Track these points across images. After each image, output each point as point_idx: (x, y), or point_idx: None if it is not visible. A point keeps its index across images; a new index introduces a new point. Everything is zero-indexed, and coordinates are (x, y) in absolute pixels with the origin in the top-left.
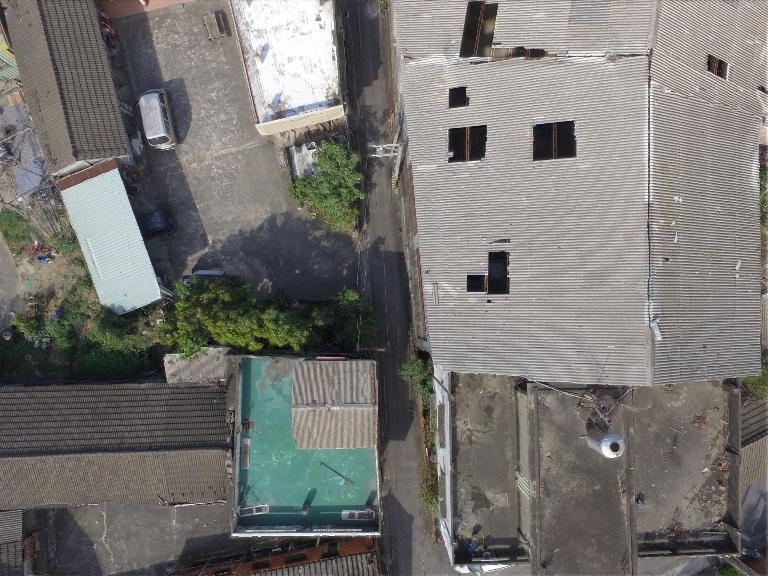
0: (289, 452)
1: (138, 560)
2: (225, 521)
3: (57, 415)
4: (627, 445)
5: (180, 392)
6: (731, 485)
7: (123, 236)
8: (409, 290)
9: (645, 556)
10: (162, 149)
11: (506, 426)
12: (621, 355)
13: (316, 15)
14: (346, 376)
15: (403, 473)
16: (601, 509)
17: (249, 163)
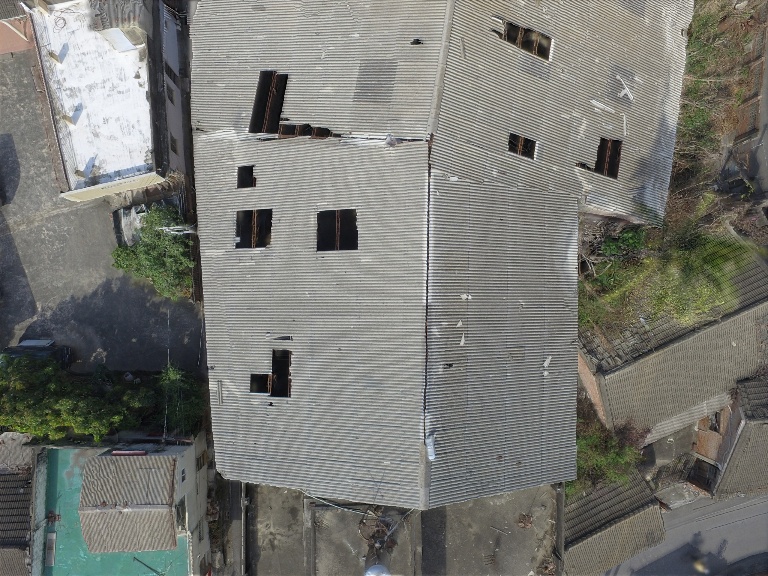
0: None
1: None
2: None
3: None
4: (413, 566)
5: None
6: None
7: None
8: None
9: None
10: None
11: None
12: (397, 473)
13: (135, 72)
14: (143, 473)
15: None
16: None
17: (83, 224)
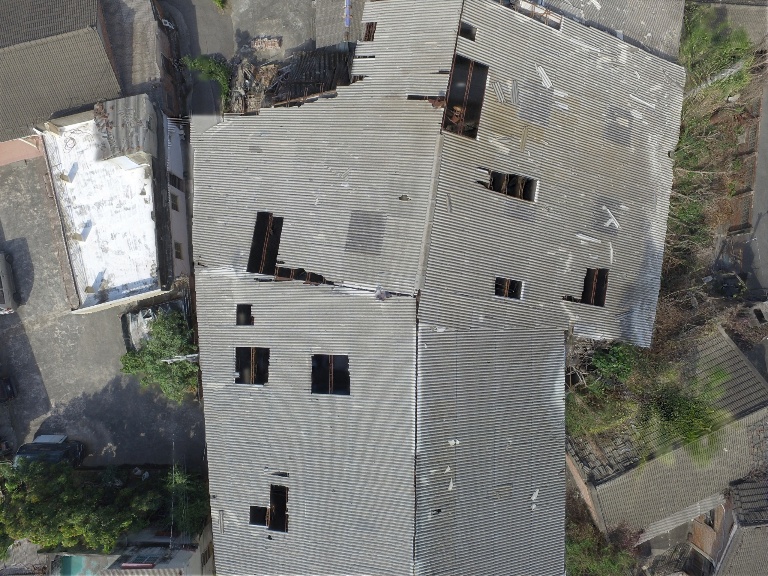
0: None
1: None
2: None
3: None
4: None
5: None
6: None
7: None
8: None
9: None
10: (1, 314)
11: None
12: None
13: (141, 189)
14: None
15: None
16: None
17: (93, 323)
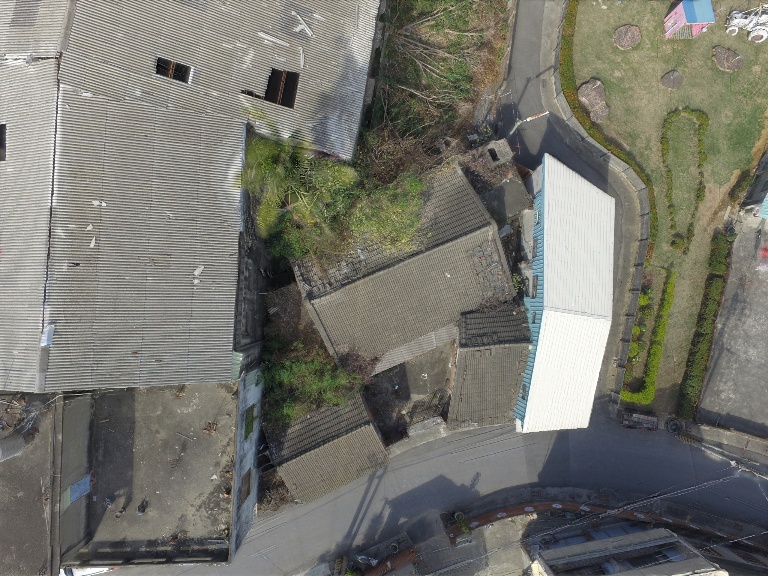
0: None
1: None
2: None
3: None
4: (52, 452)
5: None
6: None
7: None
8: None
9: (130, 564)
10: None
11: None
12: (22, 361)
13: None
14: None
15: None
16: (22, 516)
17: None
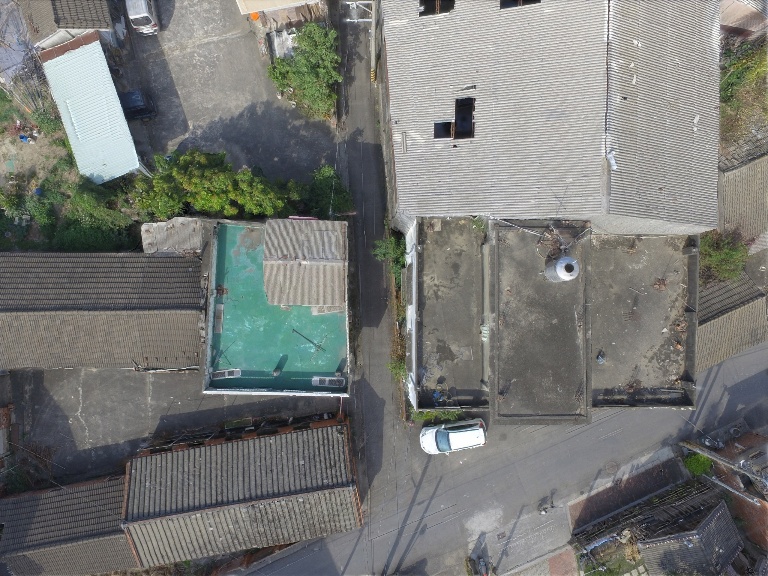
0: (262, 319)
1: (113, 435)
2: (200, 399)
3: (34, 278)
4: (584, 281)
5: (156, 261)
6: (688, 344)
7: (102, 97)
8: (385, 175)
9: (603, 407)
10: (145, 33)
11: (472, 282)
12: (578, 187)
13: None
14: (317, 234)
15: (376, 359)
16: (558, 342)
17: (231, 52)
